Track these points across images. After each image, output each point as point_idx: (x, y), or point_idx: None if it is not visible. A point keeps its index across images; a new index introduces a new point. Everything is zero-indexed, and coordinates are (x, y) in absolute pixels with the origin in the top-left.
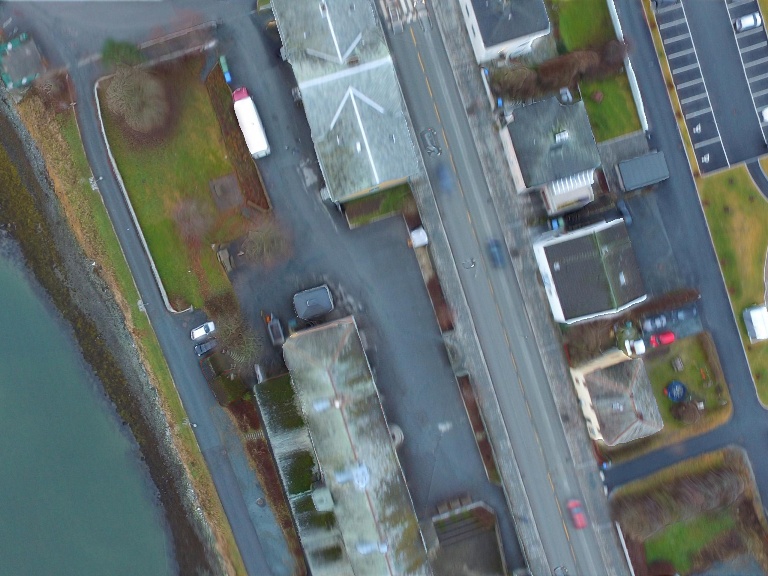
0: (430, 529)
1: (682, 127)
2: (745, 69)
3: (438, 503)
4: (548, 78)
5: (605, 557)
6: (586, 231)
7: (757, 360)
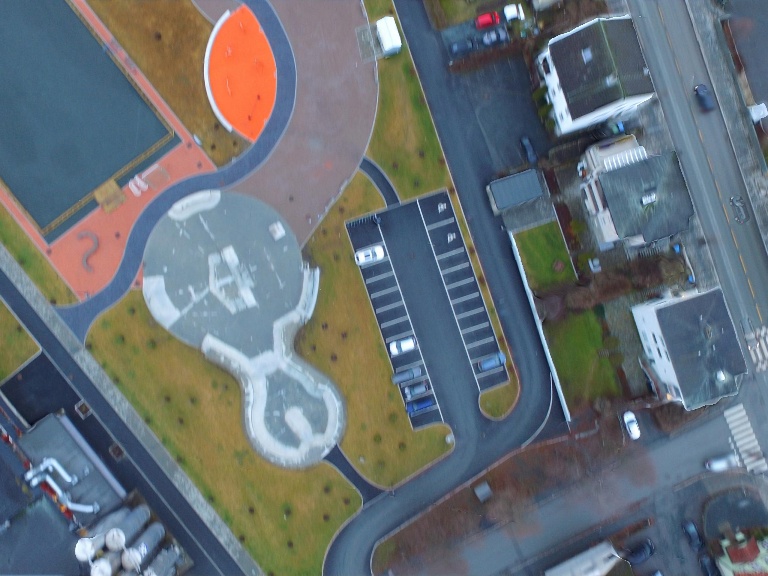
0: None
1: (469, 239)
2: (403, 300)
3: None
4: (619, 279)
5: None
6: (630, 101)
7: (383, 0)
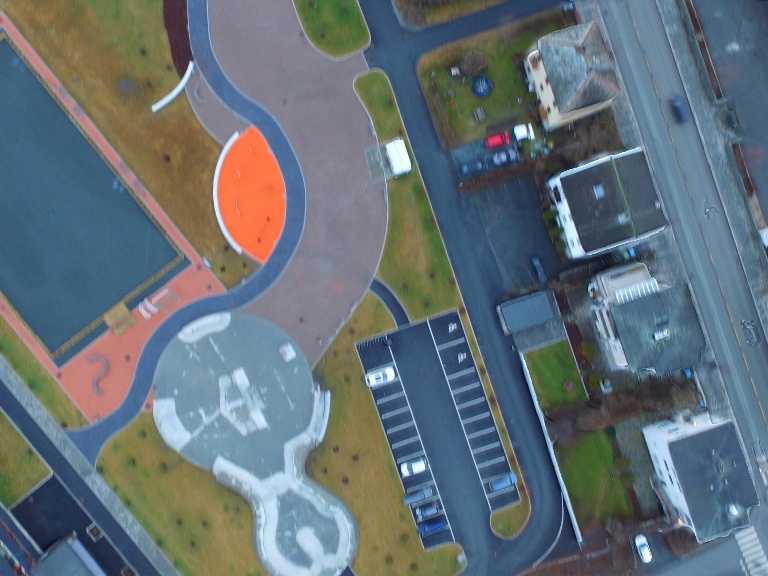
0: None
1: (479, 359)
2: (414, 420)
3: None
4: (630, 401)
5: None
6: None
7: (393, 120)
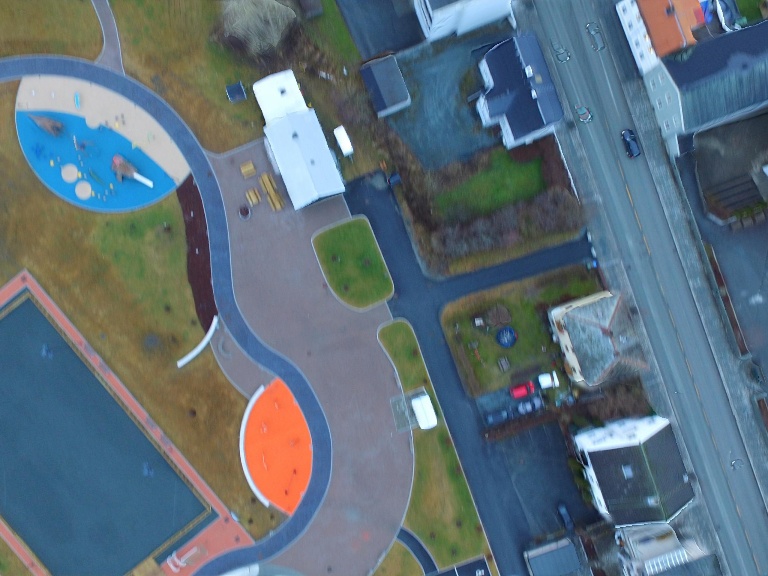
0: (767, 194)
1: None
2: None
3: (765, 223)
4: None
5: (589, 168)
6: None
7: (417, 369)
